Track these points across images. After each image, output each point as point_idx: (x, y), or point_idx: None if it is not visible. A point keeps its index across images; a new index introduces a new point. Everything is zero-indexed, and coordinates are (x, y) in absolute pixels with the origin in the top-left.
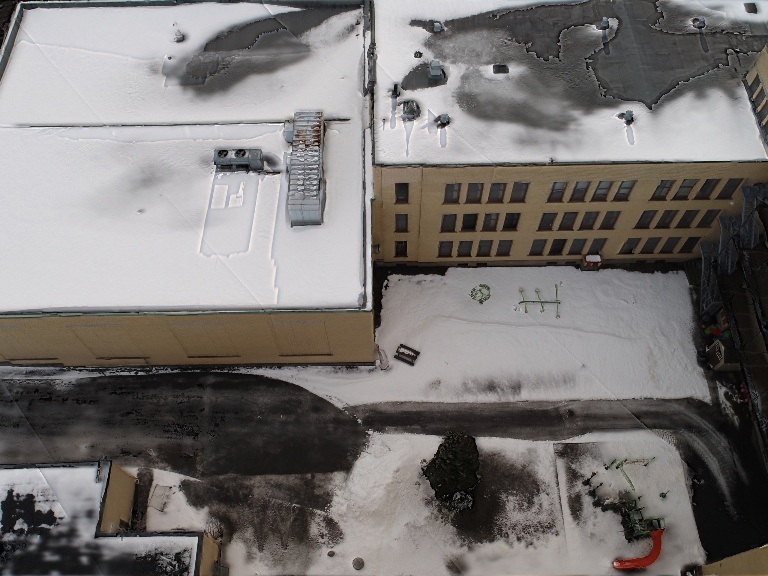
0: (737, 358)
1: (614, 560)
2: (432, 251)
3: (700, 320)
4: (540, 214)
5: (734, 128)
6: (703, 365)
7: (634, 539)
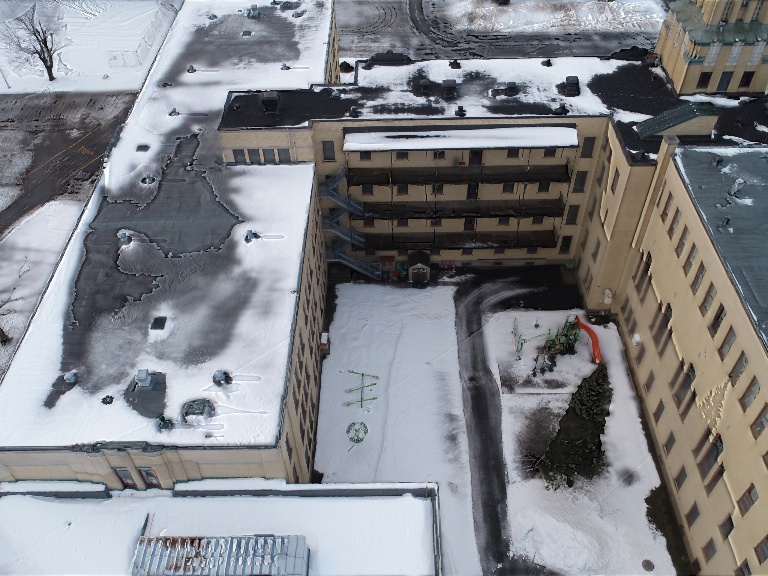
0: (427, 260)
1: (594, 363)
2: (306, 472)
3: (385, 281)
4: (308, 344)
5: (277, 178)
6: (425, 286)
7: (574, 349)
